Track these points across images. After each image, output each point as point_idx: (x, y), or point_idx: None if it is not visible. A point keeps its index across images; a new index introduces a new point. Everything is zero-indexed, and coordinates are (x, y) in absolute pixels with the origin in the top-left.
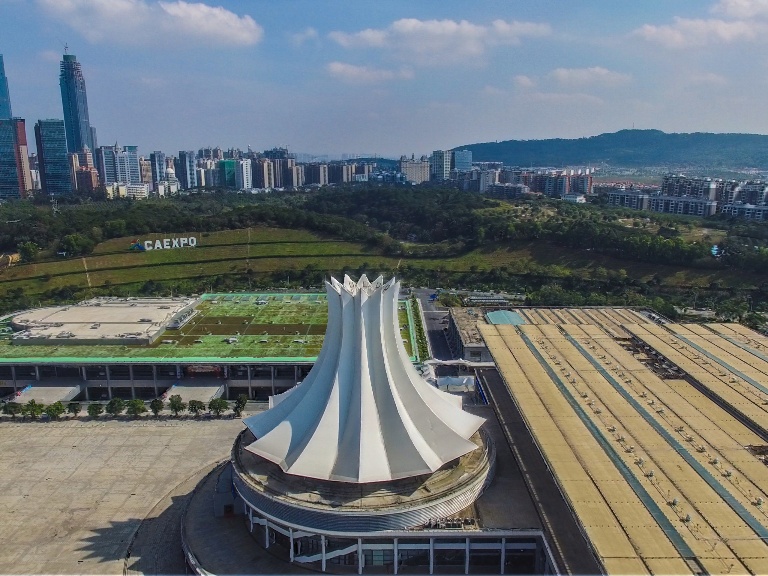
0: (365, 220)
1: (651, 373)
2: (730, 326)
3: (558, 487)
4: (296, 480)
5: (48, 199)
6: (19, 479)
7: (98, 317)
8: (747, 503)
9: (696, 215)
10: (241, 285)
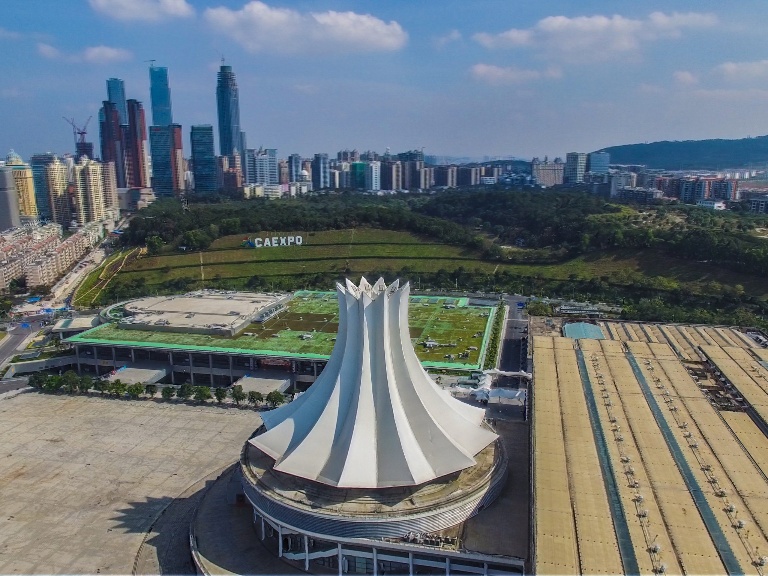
0: (479, 223)
1: (706, 402)
2: None
3: None
4: (289, 477)
5: (179, 198)
6: (87, 449)
7: (195, 308)
8: (746, 562)
9: None
10: None
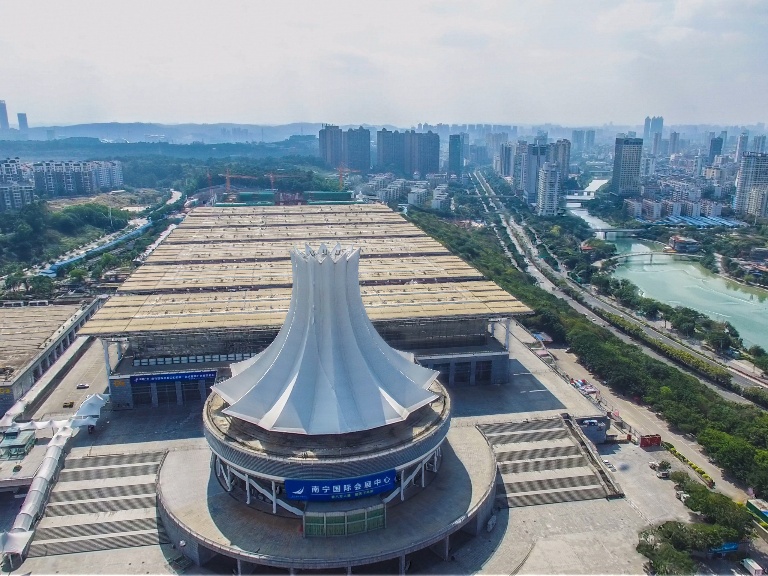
0: None
1: (254, 291)
2: (147, 268)
3: (434, 318)
4: (420, 412)
5: None
6: None
7: None
8: None
9: None
10: None
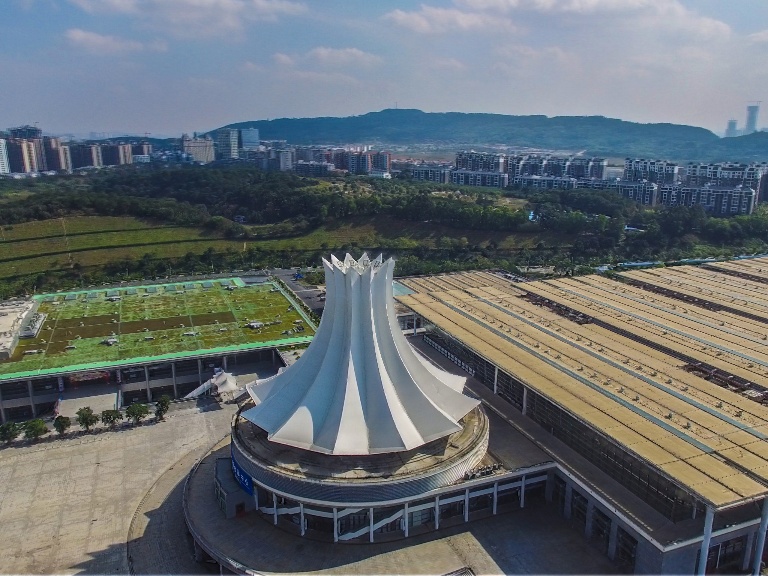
0: None
1: (569, 321)
2: (592, 277)
3: (580, 421)
4: (332, 461)
5: None
6: None
7: None
8: (714, 407)
9: (493, 186)
10: (69, 282)
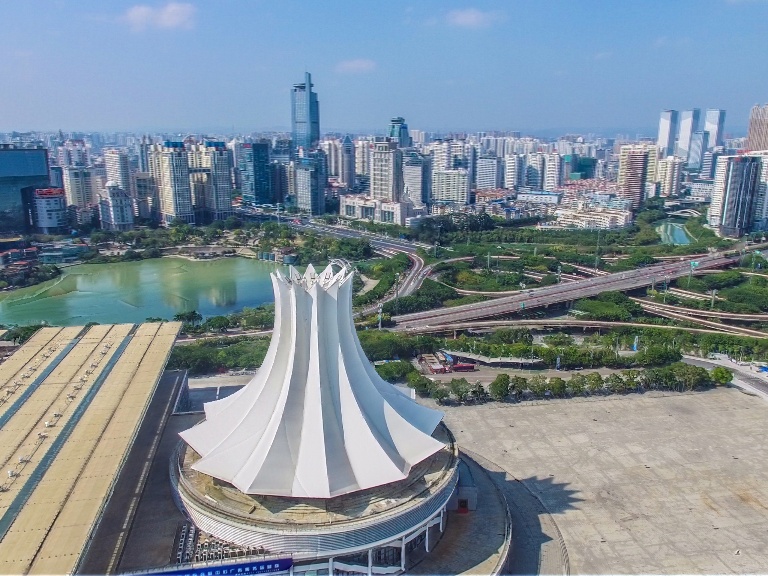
0: None
1: None
2: None
3: None
4: None
5: None
6: None
7: None
8: None
9: None
10: None
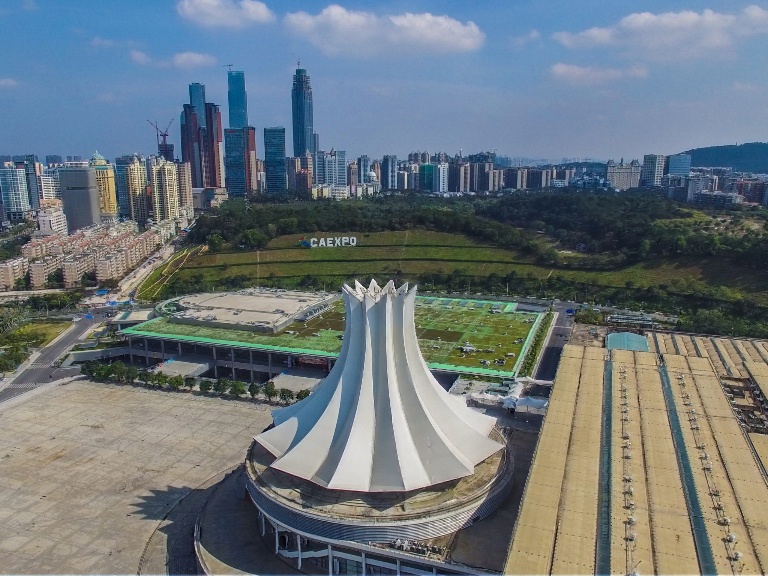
0: (542, 227)
1: (734, 422)
2: None
3: None
4: (287, 475)
5: (242, 198)
6: (123, 437)
7: (244, 305)
8: None
9: None
10: None
